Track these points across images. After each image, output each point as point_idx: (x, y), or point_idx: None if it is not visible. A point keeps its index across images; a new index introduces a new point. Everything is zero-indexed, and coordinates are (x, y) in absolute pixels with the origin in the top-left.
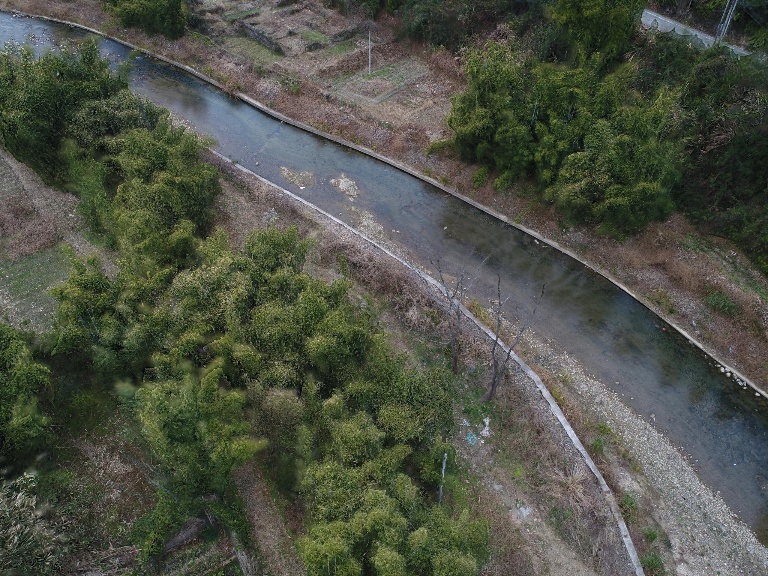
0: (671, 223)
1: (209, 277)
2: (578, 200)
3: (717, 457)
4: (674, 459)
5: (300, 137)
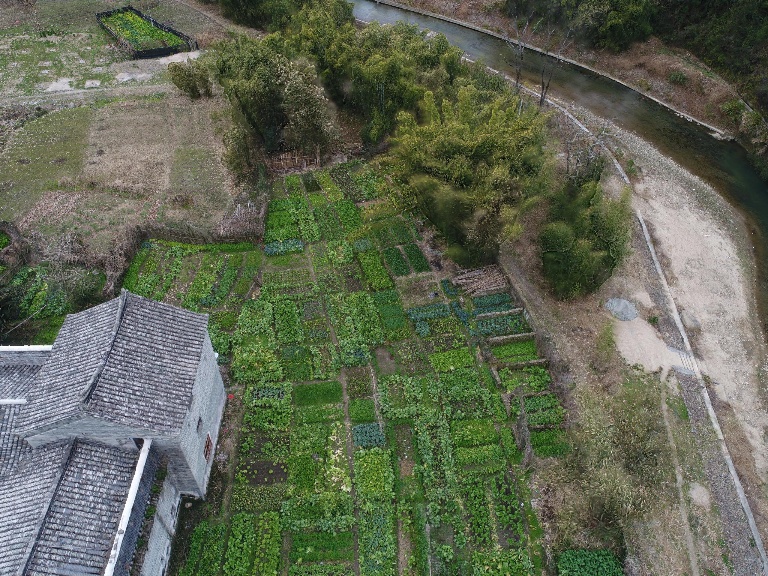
0: (650, 42)
1: (380, 33)
2: (590, 26)
3: (671, 146)
4: (646, 146)
5: (392, 11)
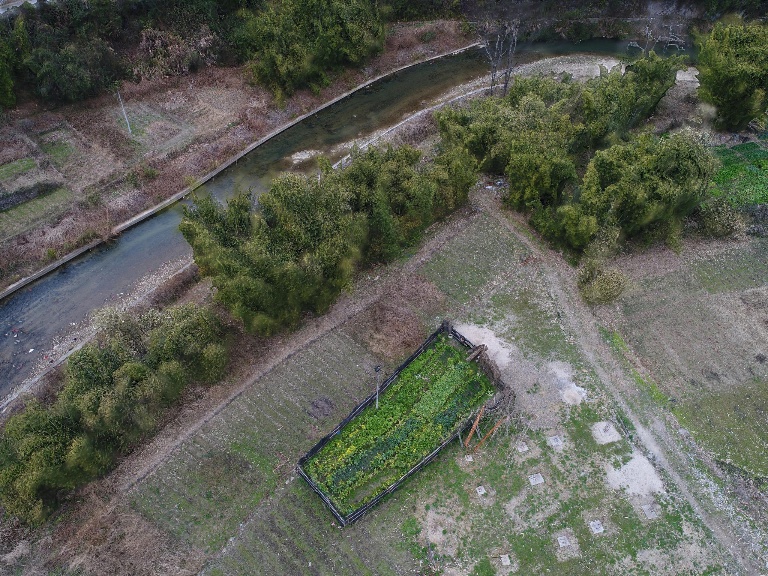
0: None
1: None
2: (369, 45)
3: None
4: None
5: (215, 186)
